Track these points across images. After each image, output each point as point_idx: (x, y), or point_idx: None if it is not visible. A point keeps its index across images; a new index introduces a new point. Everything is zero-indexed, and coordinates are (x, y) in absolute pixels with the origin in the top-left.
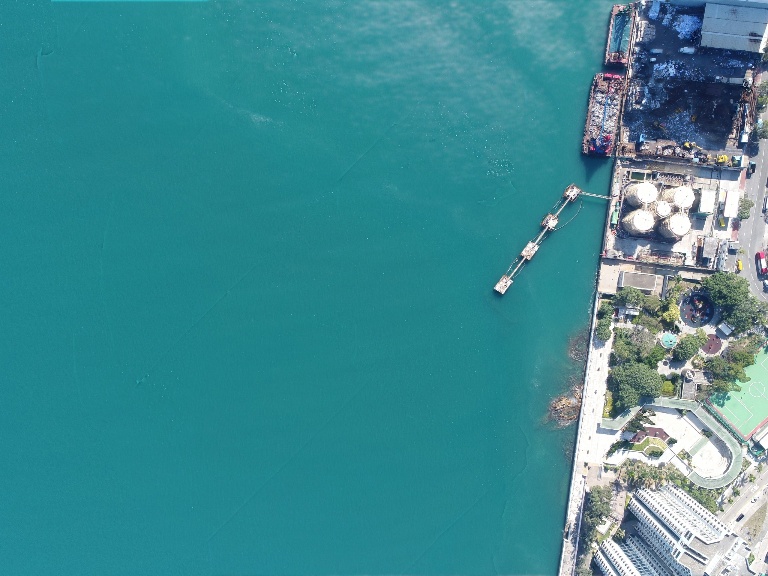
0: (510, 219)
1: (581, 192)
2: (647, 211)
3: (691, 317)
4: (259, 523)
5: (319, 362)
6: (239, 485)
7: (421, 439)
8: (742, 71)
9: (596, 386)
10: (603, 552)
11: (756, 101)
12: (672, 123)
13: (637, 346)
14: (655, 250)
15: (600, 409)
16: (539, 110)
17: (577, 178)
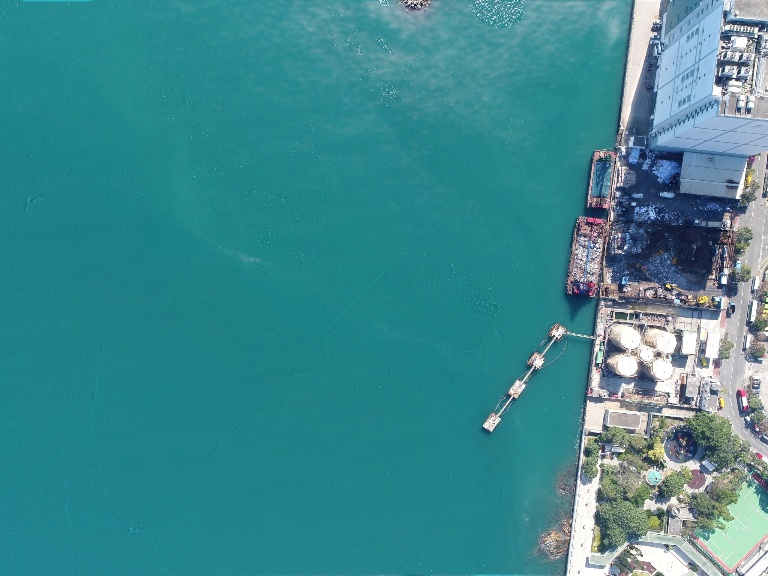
0: (497, 356)
1: (566, 332)
2: (630, 357)
3: (675, 453)
4: None
5: (311, 511)
6: None
7: None
8: (720, 214)
9: (584, 521)
10: None
11: (734, 246)
12: (653, 265)
13: (623, 486)
14: (639, 390)
15: (588, 544)
16: (524, 255)
17: (562, 317)
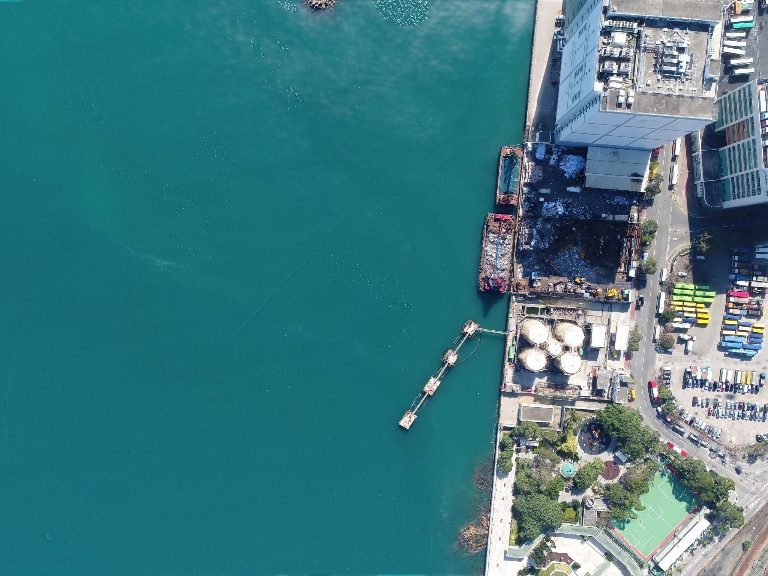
0: (412, 354)
1: (478, 328)
2: (539, 351)
3: (589, 445)
4: None
5: (225, 513)
6: None
7: None
8: (627, 207)
9: (501, 515)
10: None
11: (640, 239)
12: (563, 259)
13: (536, 479)
14: (551, 383)
15: (506, 537)
16: (433, 253)
17: (475, 313)
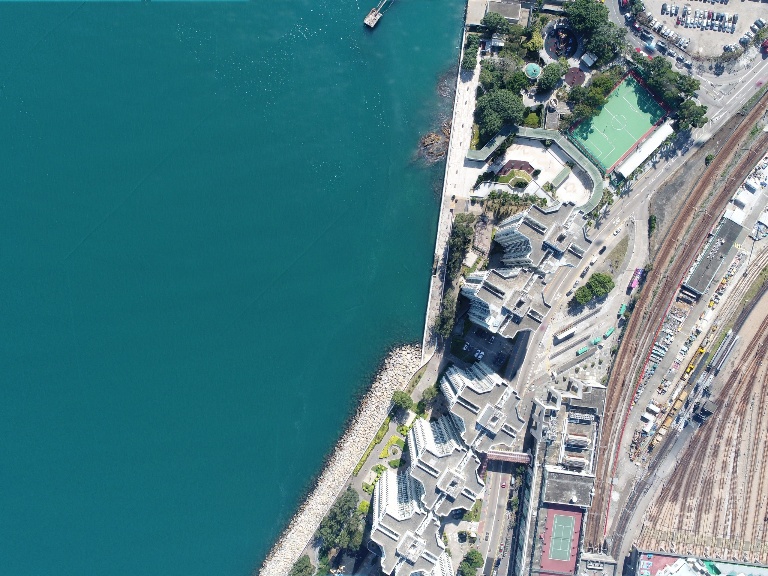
0: None
1: None
2: None
3: (556, 50)
4: (118, 240)
5: (180, 75)
6: (99, 203)
7: (283, 156)
8: None
9: (463, 120)
10: None
11: None
12: None
13: (500, 70)
14: None
15: (467, 143)
16: None
17: None
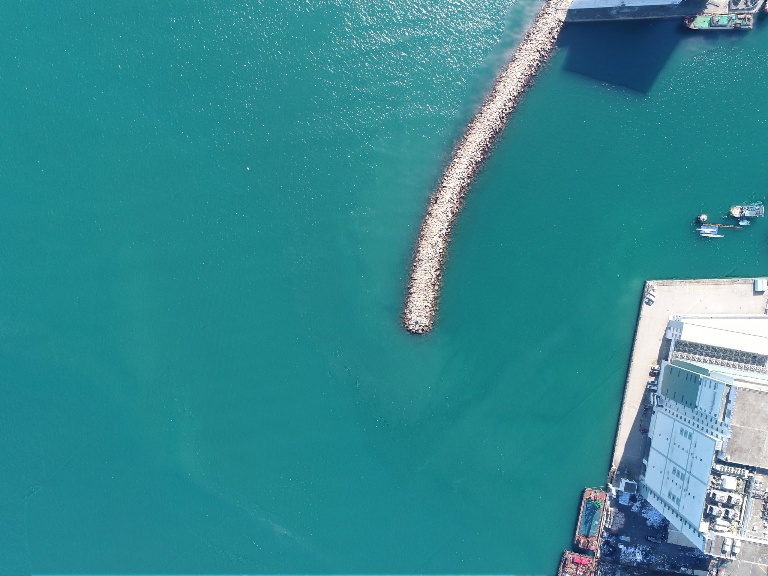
0: None
1: None
2: None
3: None
4: None
5: None
6: None
7: None
8: (707, 561)
9: None
10: None
11: None
12: None
13: None
14: None
15: None
16: None
17: None
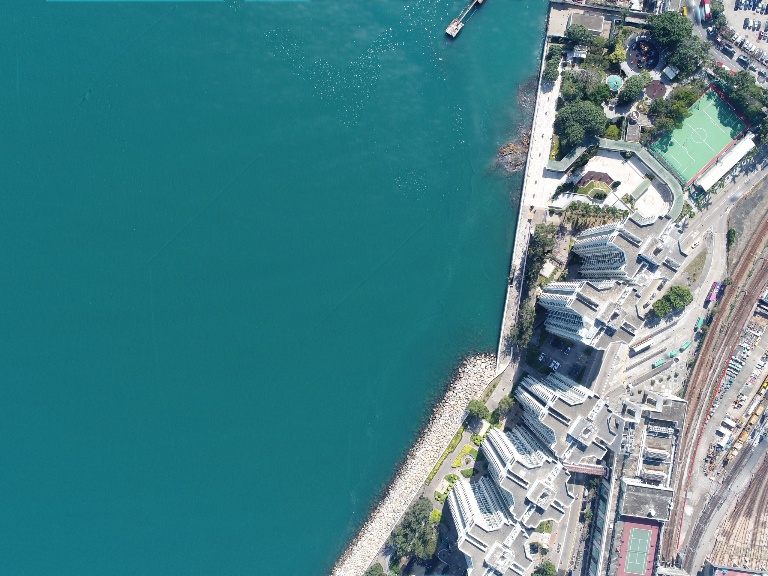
0: None
1: None
2: None
3: (637, 63)
4: (201, 244)
5: (267, 81)
6: (182, 207)
7: (367, 163)
8: None
9: (543, 130)
10: (546, 292)
11: None
12: None
13: (583, 82)
14: None
15: (547, 153)
16: None
17: None
